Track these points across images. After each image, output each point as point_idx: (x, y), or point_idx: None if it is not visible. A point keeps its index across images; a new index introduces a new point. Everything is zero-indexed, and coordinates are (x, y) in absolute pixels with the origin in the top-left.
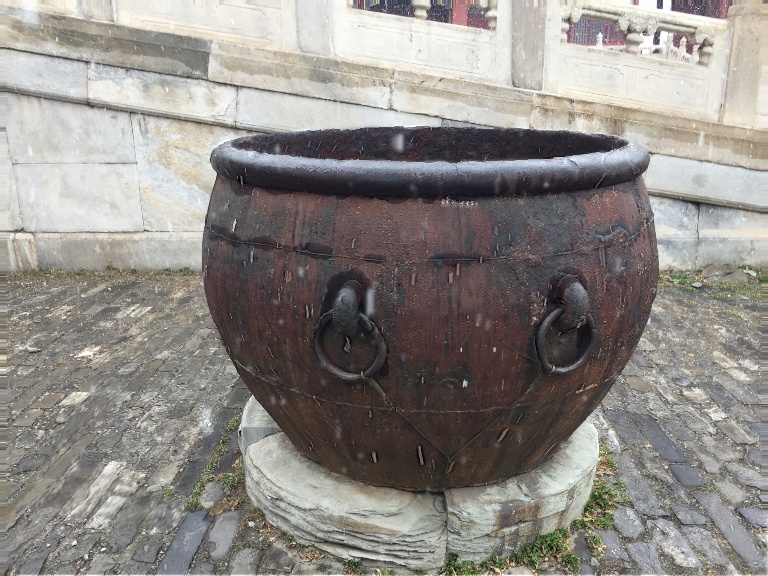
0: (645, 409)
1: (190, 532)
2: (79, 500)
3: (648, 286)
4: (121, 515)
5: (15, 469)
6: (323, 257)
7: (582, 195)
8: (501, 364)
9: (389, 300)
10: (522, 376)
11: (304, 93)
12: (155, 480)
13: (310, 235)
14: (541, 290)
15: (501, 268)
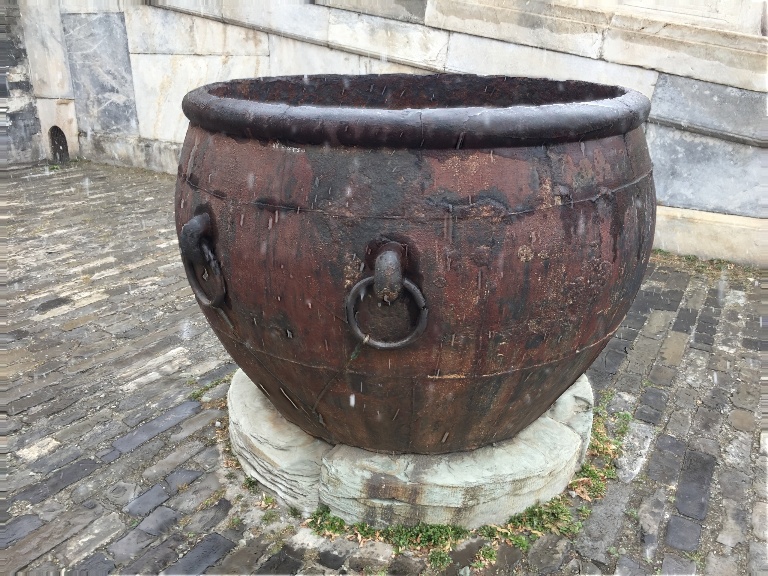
0: (717, 449)
1: (175, 415)
2: (134, 368)
3: (549, 278)
4: (147, 387)
5: (121, 334)
6: (195, 188)
7: (434, 155)
8: (319, 322)
9: (225, 237)
10: (345, 341)
11: (511, 39)
12: (192, 369)
13: (192, 167)
14: (358, 253)
15: (317, 222)
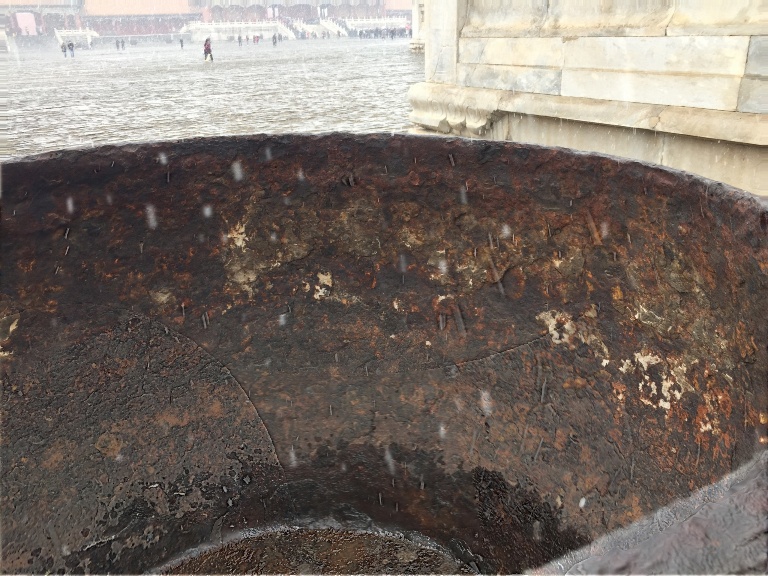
0: None
1: None
2: None
3: None
4: None
5: None
6: None
7: None
8: None
9: None
10: None
11: None
12: None
13: None
14: None
15: None
